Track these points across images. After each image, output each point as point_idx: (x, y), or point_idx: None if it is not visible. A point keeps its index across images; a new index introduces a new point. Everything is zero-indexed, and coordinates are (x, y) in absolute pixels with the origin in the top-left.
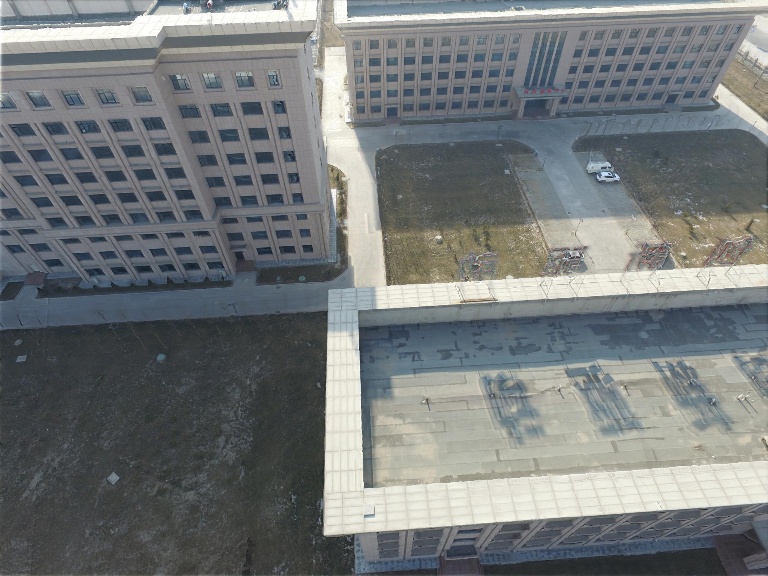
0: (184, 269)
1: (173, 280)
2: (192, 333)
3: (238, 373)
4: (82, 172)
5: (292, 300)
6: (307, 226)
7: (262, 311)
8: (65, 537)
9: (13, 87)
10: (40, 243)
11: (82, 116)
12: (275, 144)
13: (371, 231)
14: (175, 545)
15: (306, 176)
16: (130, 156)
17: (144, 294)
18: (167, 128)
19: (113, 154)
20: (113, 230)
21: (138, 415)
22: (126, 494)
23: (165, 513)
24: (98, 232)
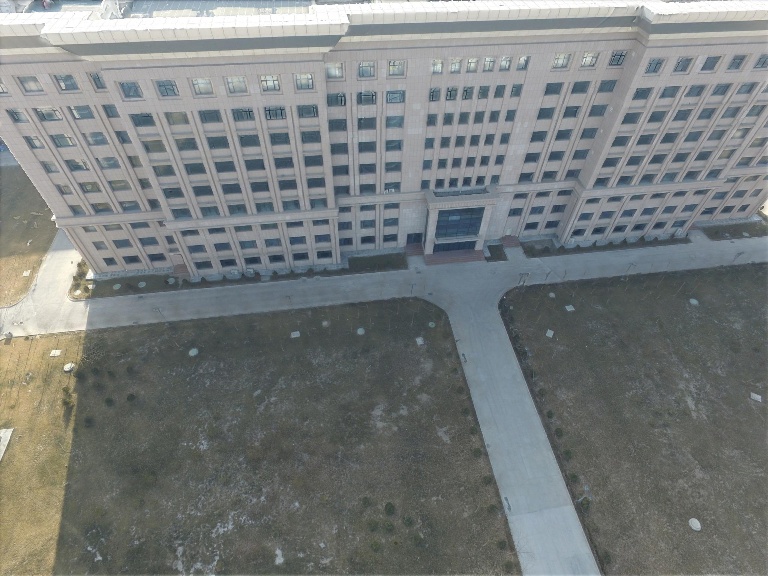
0: (651, 228)
1: (636, 239)
2: (699, 281)
3: None
4: (671, 133)
5: (755, 252)
6: (764, 186)
7: (739, 261)
8: (764, 444)
9: (706, 52)
10: (540, 206)
11: (728, 79)
12: None
13: None
14: None
15: None
16: None
17: (621, 251)
18: None
19: (713, 115)
20: (640, 189)
21: (722, 348)
22: None
23: None
24: (626, 191)
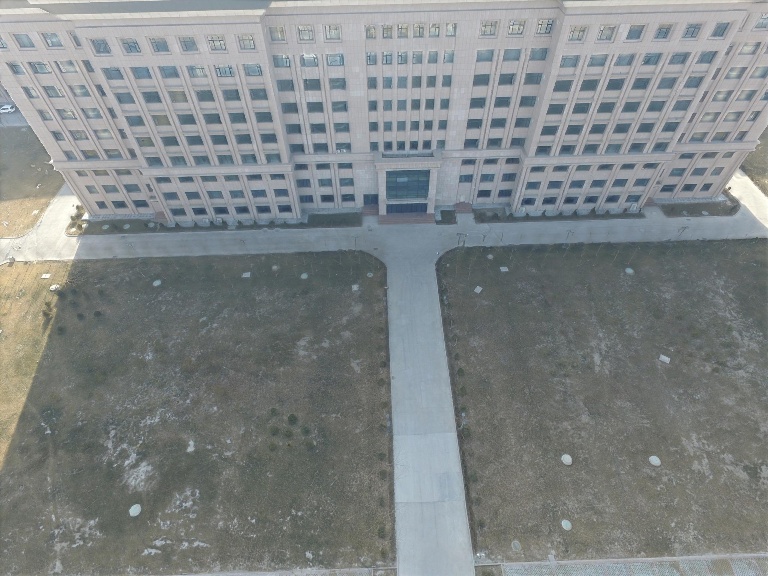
0: (604, 201)
1: None
2: (641, 253)
3: (707, 284)
4: (607, 102)
5: (710, 230)
6: (724, 164)
7: (690, 238)
8: (659, 400)
9: (627, 20)
10: (490, 173)
11: (657, 48)
12: (767, 82)
13: (738, 177)
14: (760, 408)
15: (766, 114)
16: (657, 88)
17: (570, 222)
18: (714, 62)
19: (647, 85)
20: (584, 159)
21: (645, 314)
22: (685, 371)
23: (731, 385)
24: (570, 161)
